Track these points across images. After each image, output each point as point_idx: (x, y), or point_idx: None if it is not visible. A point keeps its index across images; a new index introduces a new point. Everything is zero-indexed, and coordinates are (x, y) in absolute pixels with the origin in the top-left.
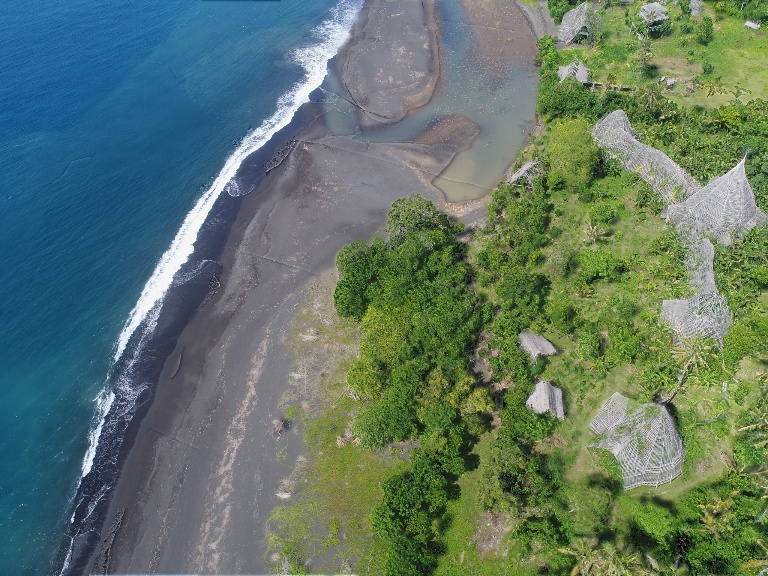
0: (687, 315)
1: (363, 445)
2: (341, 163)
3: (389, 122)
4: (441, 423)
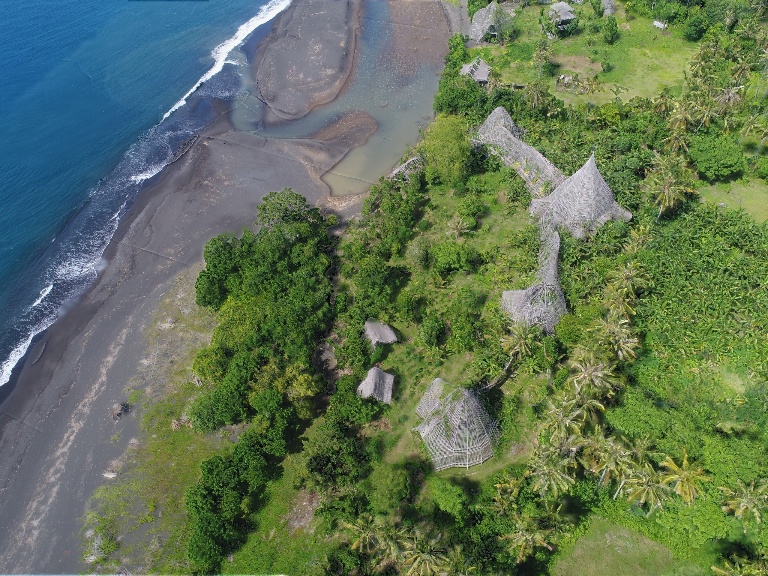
0: (522, 305)
1: (195, 428)
2: (236, 158)
3: (292, 118)
4: (267, 407)
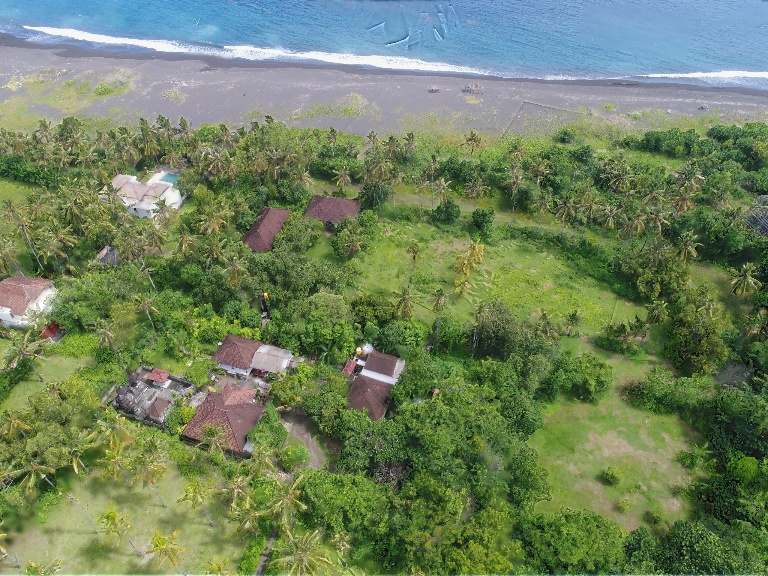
0: None
1: None
2: None
3: None
4: (740, 144)
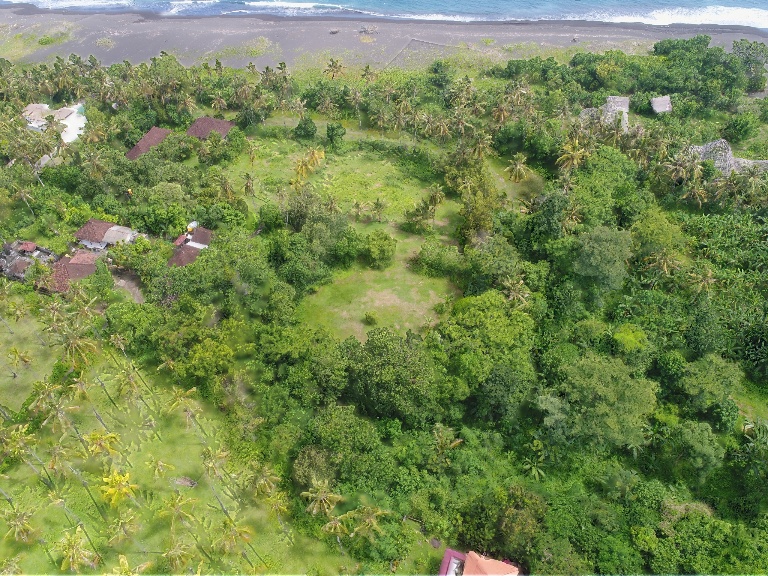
0: None
1: None
2: None
3: None
4: (589, 68)
